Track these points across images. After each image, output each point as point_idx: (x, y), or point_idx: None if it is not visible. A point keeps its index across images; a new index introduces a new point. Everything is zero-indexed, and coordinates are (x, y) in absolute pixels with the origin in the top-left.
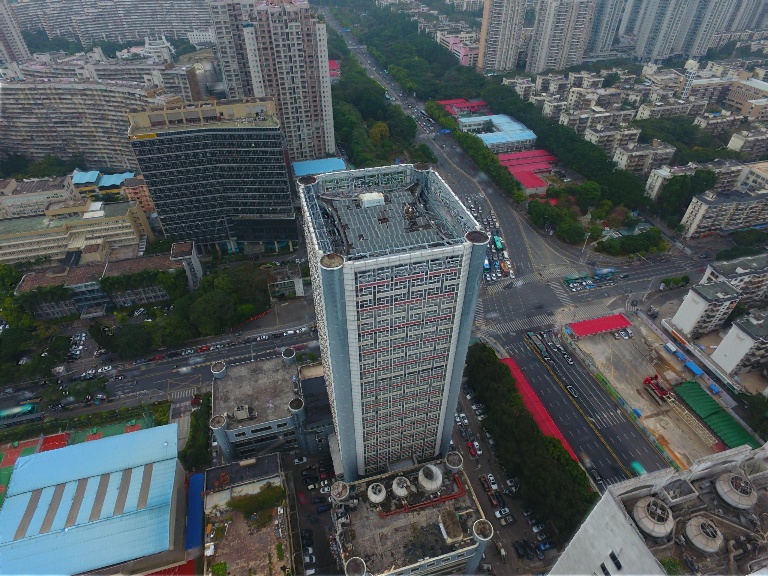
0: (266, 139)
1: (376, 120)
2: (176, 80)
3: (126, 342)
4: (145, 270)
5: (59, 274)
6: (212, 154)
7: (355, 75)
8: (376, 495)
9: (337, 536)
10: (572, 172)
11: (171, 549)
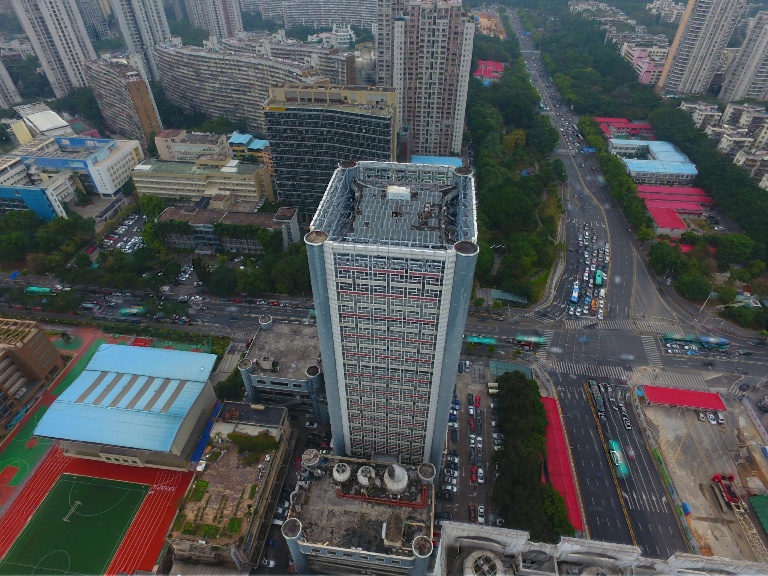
0: (376, 127)
1: (518, 127)
2: (336, 65)
3: (216, 280)
4: (250, 224)
5: (190, 213)
6: (328, 133)
7: (514, 79)
8: (338, 473)
9: (291, 495)
10: (730, 221)
11: (178, 455)
